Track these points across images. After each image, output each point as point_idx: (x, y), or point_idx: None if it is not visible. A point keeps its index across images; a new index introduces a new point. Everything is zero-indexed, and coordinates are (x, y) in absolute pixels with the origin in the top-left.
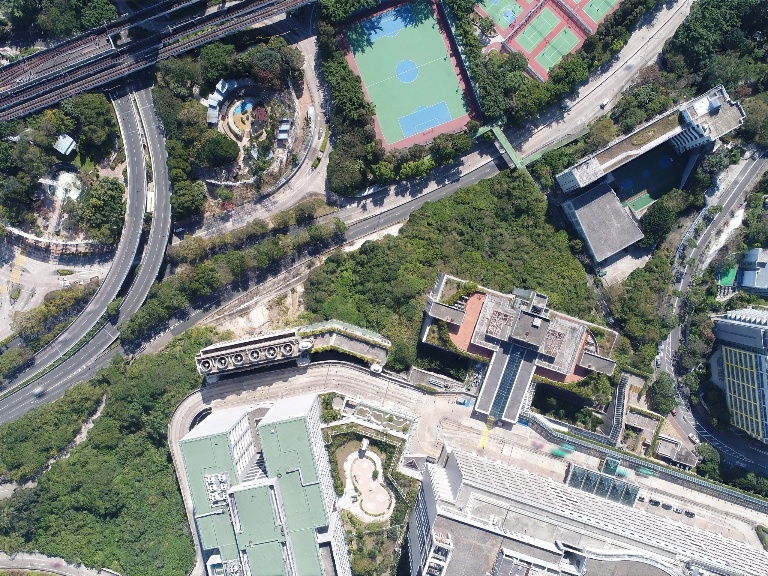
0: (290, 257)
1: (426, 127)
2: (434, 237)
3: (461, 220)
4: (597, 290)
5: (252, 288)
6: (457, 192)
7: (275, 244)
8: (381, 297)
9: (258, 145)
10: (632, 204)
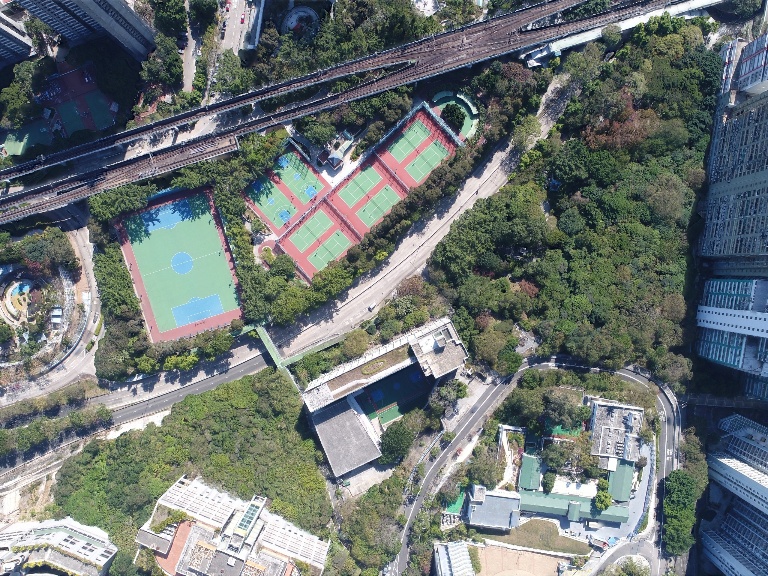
0: (58, 437)
1: (198, 318)
2: (185, 436)
3: (219, 417)
4: (337, 502)
5: (19, 465)
6: (218, 388)
7: (37, 428)
8: (117, 501)
9: (29, 329)
10: (381, 416)
